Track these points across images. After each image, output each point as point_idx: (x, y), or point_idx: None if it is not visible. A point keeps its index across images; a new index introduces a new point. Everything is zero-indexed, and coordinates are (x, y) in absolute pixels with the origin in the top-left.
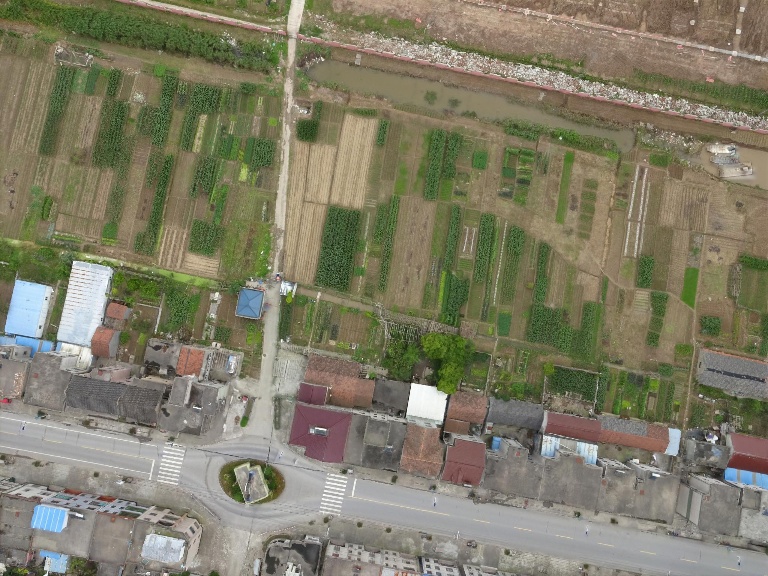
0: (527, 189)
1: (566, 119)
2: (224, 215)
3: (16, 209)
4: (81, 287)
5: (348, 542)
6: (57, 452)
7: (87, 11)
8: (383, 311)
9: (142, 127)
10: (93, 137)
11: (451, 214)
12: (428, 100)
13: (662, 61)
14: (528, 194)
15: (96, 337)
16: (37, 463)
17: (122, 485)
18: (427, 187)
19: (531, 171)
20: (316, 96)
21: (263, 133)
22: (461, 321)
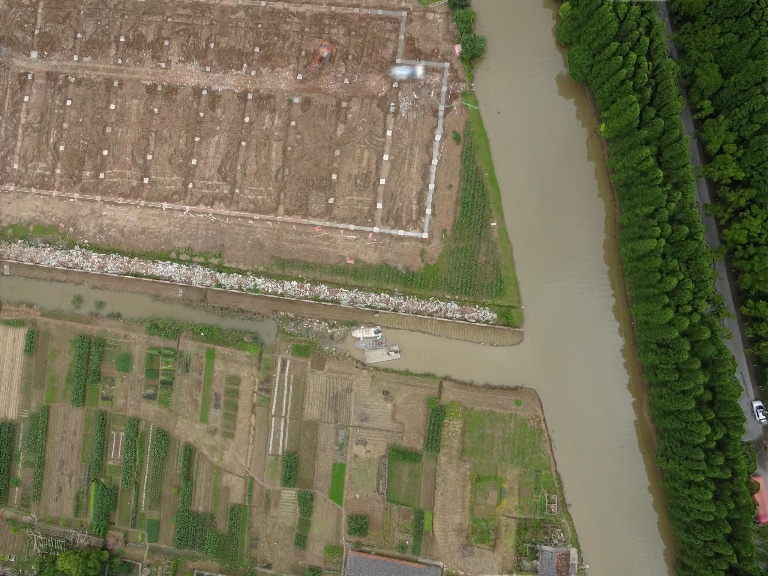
0: (169, 390)
1: None
2: None
3: None
4: None
5: None
6: None
7: None
8: None
9: None
10: None
11: (96, 421)
12: (75, 304)
13: (300, 245)
14: (172, 395)
15: None
16: None
17: None
18: (72, 395)
19: (173, 371)
20: None
21: None
22: None
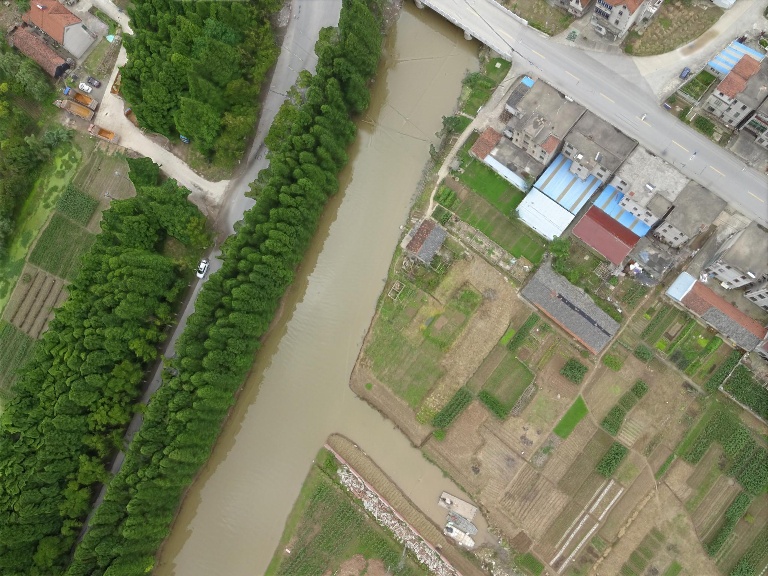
0: None
1: None
2: None
3: None
4: None
5: None
6: None
7: None
8: None
9: None
10: None
11: None
12: None
13: None
14: None
15: None
16: None
17: None
18: None
19: None
20: None
21: None
22: None
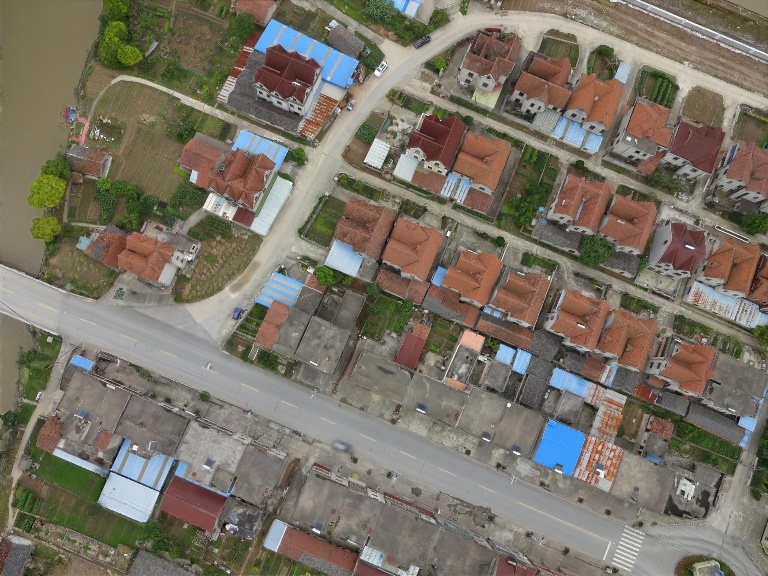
0: None
1: None
2: None
3: None
4: None
5: None
6: None
7: None
8: None
9: None
10: None
11: None
12: None
13: None
14: None
15: None
16: None
17: None
18: None
19: None
20: None
21: None
22: None
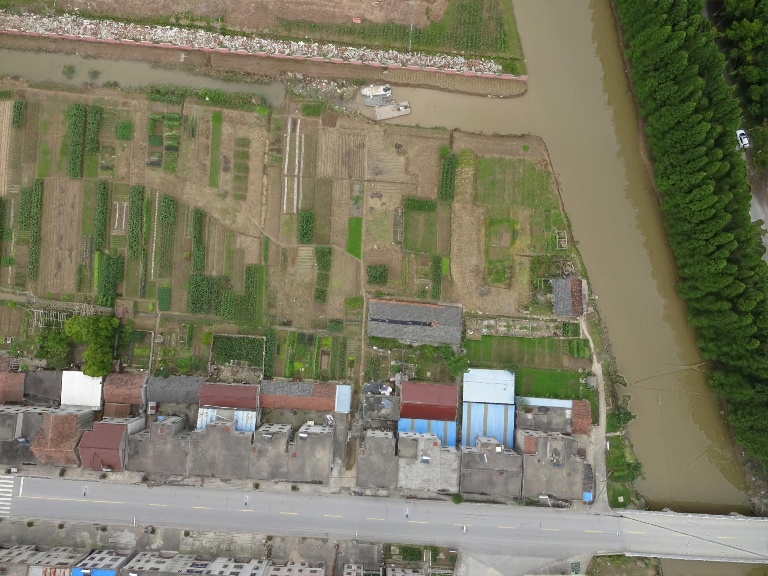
0: (175, 155)
1: (213, 78)
2: None
3: None
4: None
5: (19, 544)
6: None
7: None
8: None
9: None
10: None
11: (97, 190)
12: (66, 75)
13: (305, 7)
14: (178, 161)
15: None
16: None
17: None
18: (69, 165)
19: (178, 136)
20: None
21: None
22: None
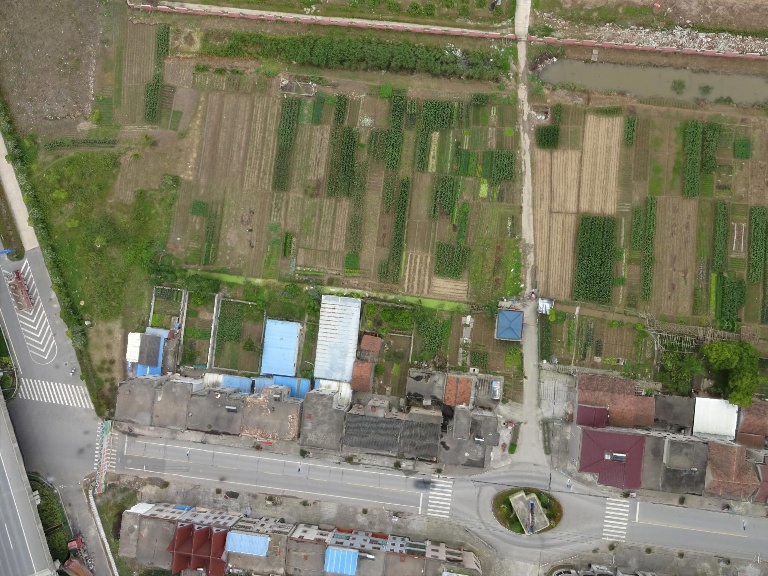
0: None
1: None
2: (468, 234)
3: (256, 248)
4: (333, 321)
5: (637, 570)
6: (323, 490)
7: (307, 39)
8: (650, 322)
9: (374, 152)
10: (325, 167)
11: (717, 211)
12: (676, 90)
13: None
14: None
15: (356, 372)
16: (305, 502)
17: (392, 520)
18: (687, 184)
19: None
20: (553, 99)
21: (500, 145)
22: (741, 326)
